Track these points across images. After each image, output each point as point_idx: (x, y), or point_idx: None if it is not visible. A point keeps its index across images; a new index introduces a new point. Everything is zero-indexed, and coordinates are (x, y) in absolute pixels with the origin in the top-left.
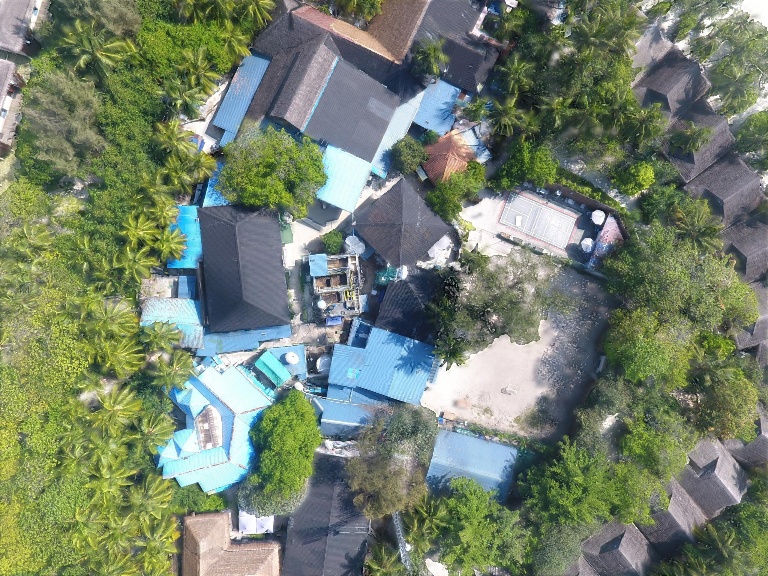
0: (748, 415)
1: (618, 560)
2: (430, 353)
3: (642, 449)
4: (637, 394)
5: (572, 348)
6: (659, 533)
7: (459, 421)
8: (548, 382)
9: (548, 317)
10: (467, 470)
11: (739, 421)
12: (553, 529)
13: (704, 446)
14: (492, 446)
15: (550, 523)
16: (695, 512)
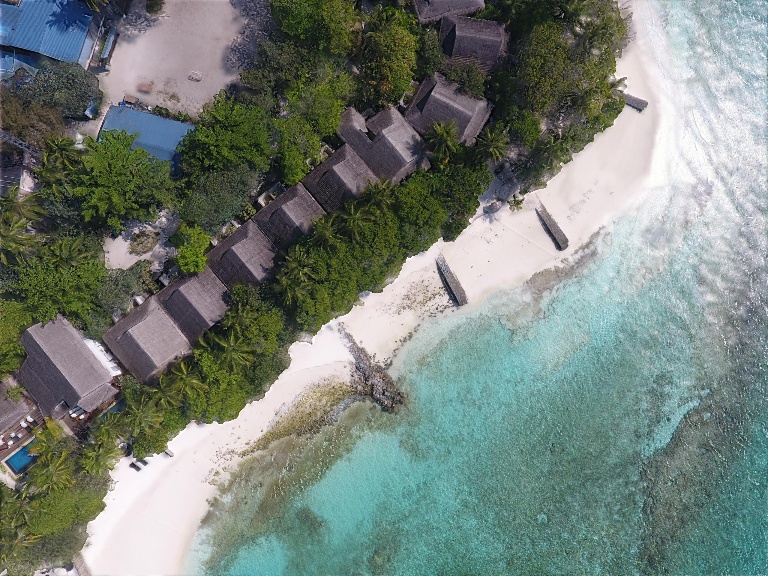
0: (401, 59)
1: (284, 220)
2: (86, 12)
3: (299, 101)
4: (303, 55)
5: (263, 36)
6: (332, 199)
7: (142, 105)
8: (238, 70)
9: (238, 5)
10: (138, 142)
11: (391, 64)
12: (203, 176)
13: (382, 116)
14: (169, 123)
15: (202, 172)
16: (372, 181)
